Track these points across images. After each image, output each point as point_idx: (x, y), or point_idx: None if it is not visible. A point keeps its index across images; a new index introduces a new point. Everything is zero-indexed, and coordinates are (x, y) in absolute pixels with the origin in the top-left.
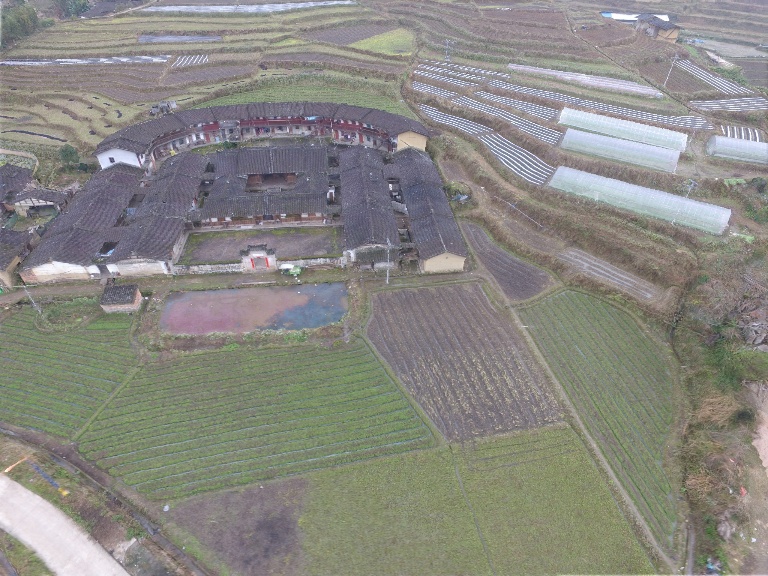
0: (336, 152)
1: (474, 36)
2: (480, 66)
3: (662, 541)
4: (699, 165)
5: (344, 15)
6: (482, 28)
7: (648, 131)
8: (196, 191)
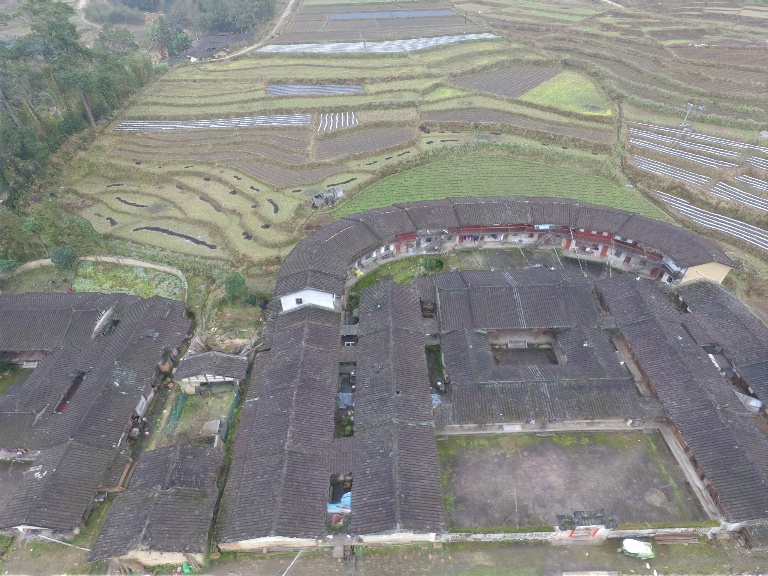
0: None
1: (688, 87)
2: (722, 134)
3: None
4: None
5: (492, 53)
6: (687, 74)
7: None
8: (425, 358)
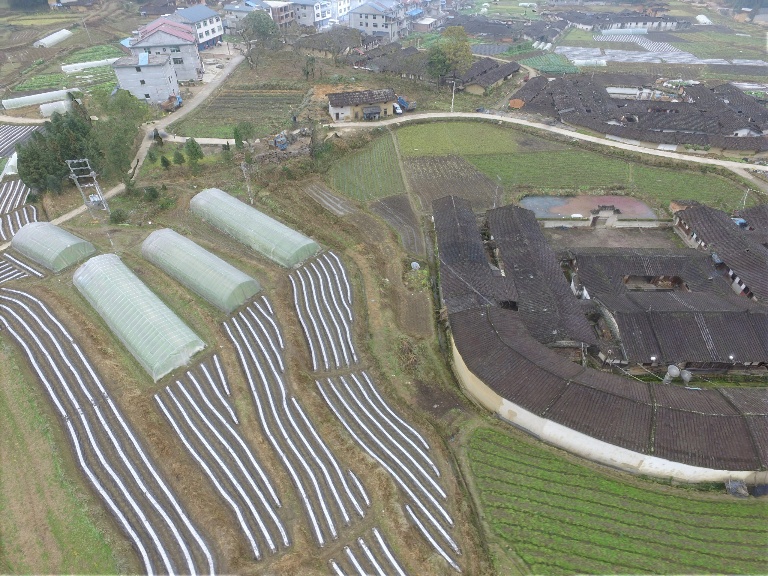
0: (603, 344)
1: None
2: None
3: None
4: (127, 246)
5: None
6: None
7: (124, 275)
8: None
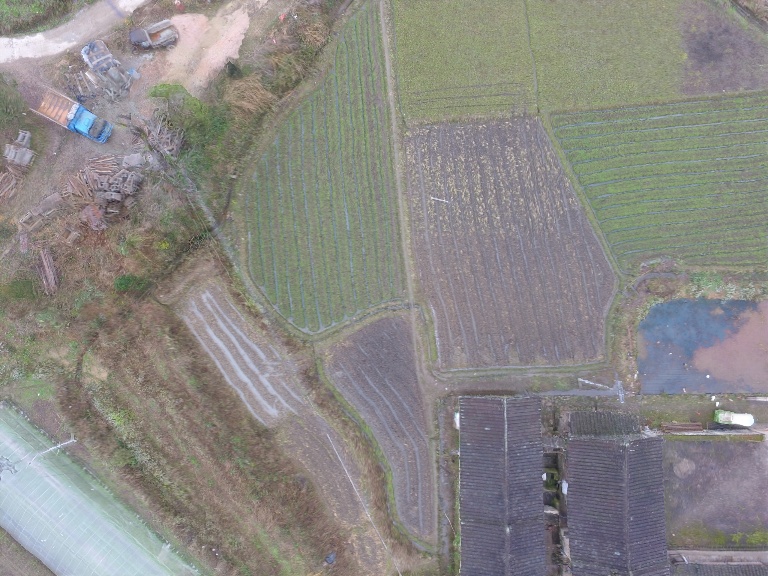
0: None
1: None
2: None
3: (374, 4)
4: None
5: None
6: None
7: None
8: None
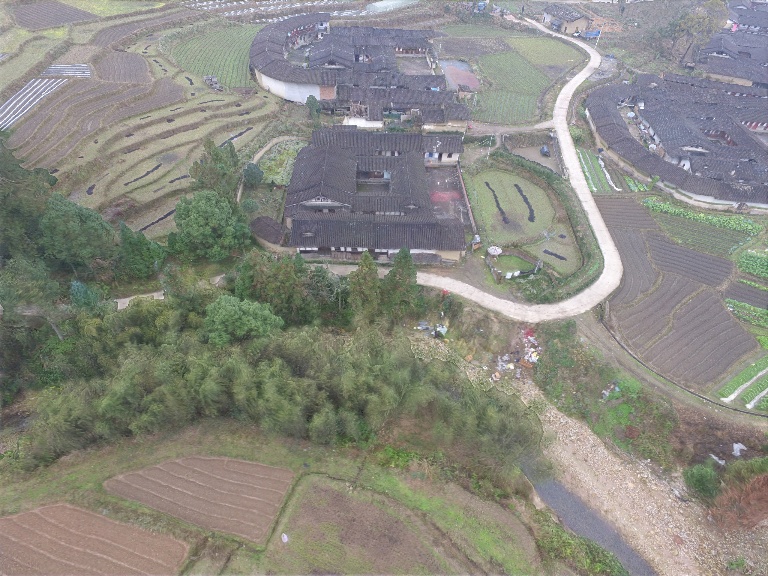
0: None
1: None
2: None
3: None
4: None
5: None
6: None
7: None
8: None
